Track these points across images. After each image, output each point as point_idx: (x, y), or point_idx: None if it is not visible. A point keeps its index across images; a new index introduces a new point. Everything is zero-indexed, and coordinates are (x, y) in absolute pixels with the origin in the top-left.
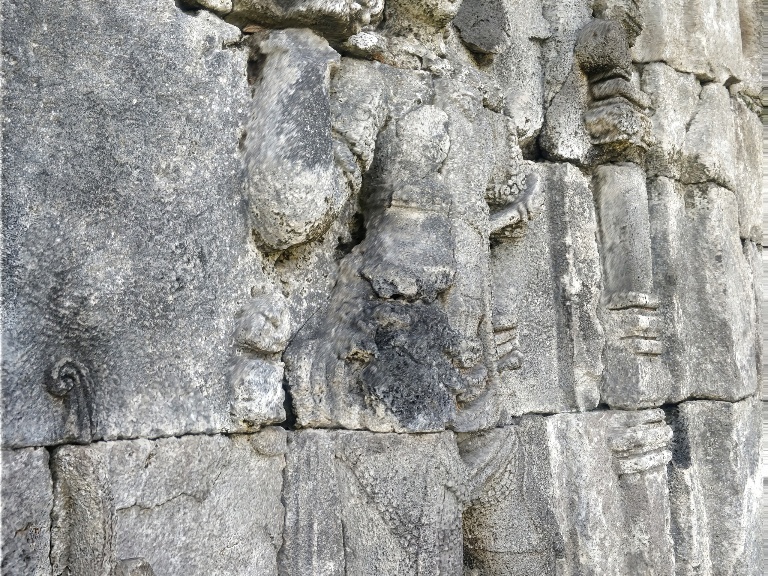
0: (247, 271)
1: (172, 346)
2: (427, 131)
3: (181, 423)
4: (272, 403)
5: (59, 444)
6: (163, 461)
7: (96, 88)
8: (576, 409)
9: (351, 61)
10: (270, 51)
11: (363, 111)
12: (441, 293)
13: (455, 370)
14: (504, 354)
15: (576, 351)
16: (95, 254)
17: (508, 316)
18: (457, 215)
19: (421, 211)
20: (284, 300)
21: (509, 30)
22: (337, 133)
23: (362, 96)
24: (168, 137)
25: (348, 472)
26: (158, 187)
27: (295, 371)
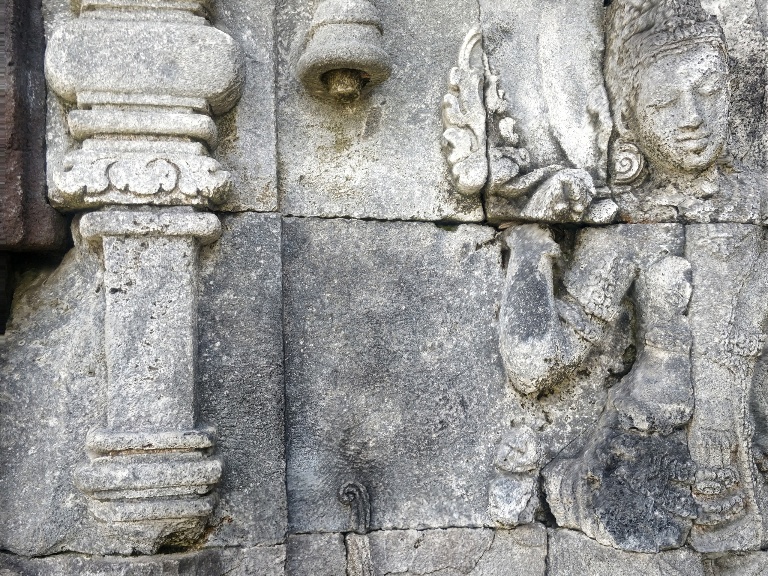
0: (506, 409)
1: (436, 468)
2: (667, 281)
3: (444, 520)
4: (514, 511)
5: (349, 531)
6: (430, 545)
7: (373, 308)
8: None
9: (594, 231)
10: (509, 246)
11: (595, 277)
12: (685, 425)
13: (680, 499)
14: None
15: None
16: (372, 415)
17: None
18: (697, 355)
19: (666, 351)
20: (531, 432)
21: None
22: (573, 298)
23: (599, 261)
24: (432, 325)
25: (588, 570)
26: (424, 361)
27: (548, 485)
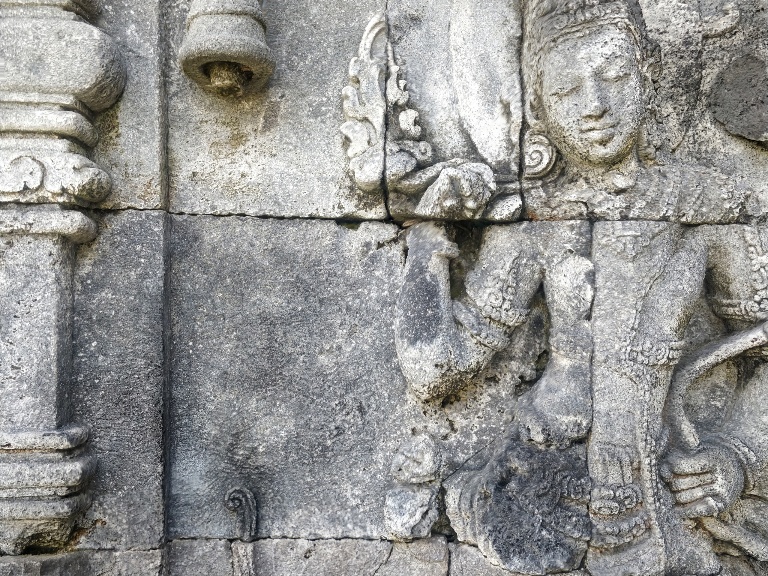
0: (407, 416)
1: (330, 476)
2: (568, 283)
3: (338, 530)
4: (407, 524)
5: (236, 538)
6: (321, 555)
7: (268, 308)
8: None
9: (497, 229)
10: None
11: (493, 278)
12: (586, 438)
13: (571, 519)
14: (693, 500)
15: None
16: (263, 419)
17: (690, 461)
18: (597, 364)
19: (568, 358)
20: (429, 441)
21: None
22: (471, 300)
23: None
24: (330, 326)
25: None
26: (321, 364)
27: (447, 497)
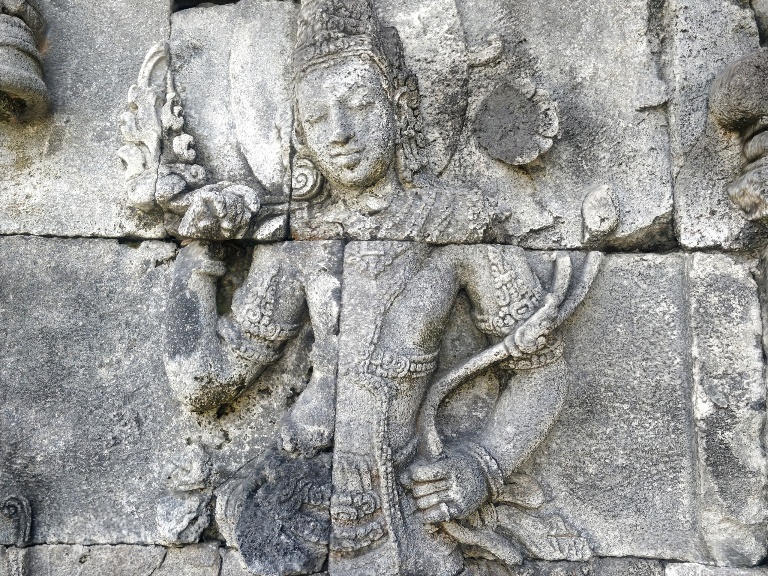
0: (182, 426)
1: (106, 484)
2: (318, 299)
3: (112, 536)
4: (174, 530)
5: (13, 544)
6: (96, 560)
7: (49, 323)
8: (714, 562)
9: (262, 248)
10: None
11: (253, 294)
12: (332, 447)
13: (309, 524)
14: (430, 505)
15: (703, 490)
16: (42, 429)
17: (425, 469)
18: (339, 376)
19: (320, 371)
20: (198, 451)
21: (545, 131)
22: None
23: None
24: (110, 341)
25: None
26: (100, 377)
27: None
